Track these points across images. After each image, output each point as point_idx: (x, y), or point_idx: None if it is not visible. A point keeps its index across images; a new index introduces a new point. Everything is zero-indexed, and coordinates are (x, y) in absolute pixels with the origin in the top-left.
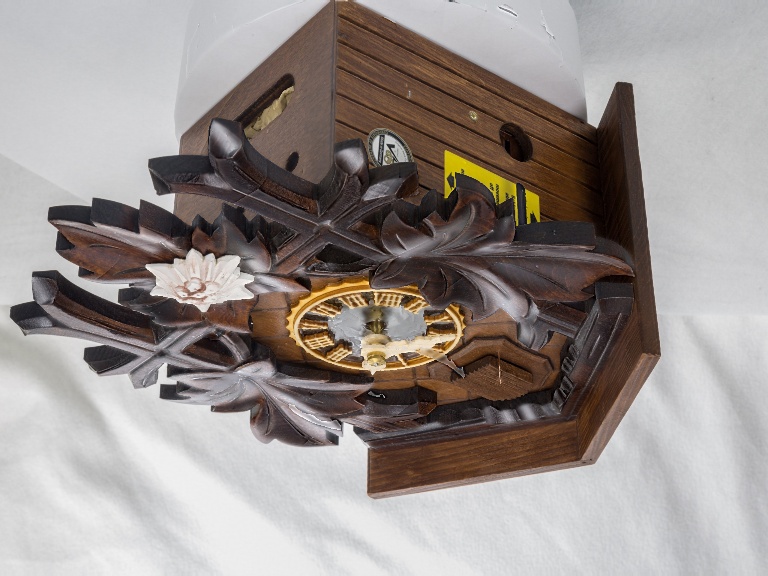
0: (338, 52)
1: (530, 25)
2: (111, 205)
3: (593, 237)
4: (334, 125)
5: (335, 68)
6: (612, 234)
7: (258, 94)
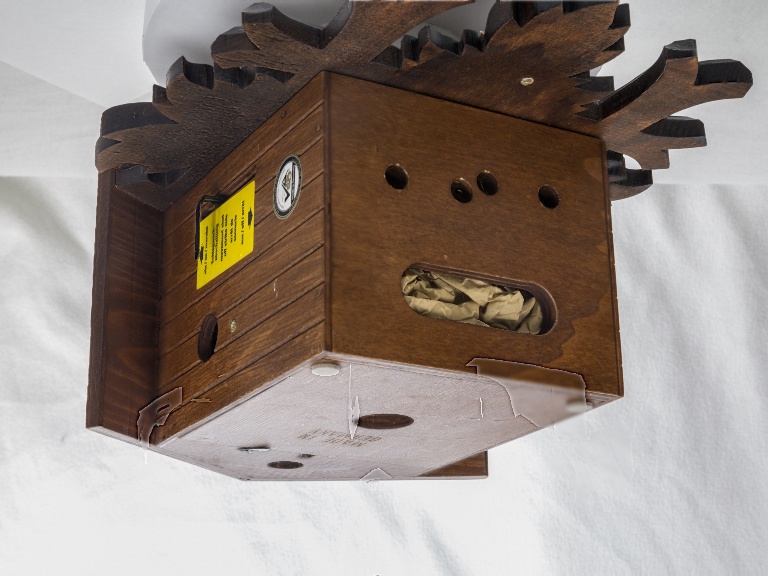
0: (323, 264)
1: (150, 415)
2: (544, 6)
3: (103, 121)
4: (325, 165)
5: (326, 242)
6: (146, 290)
7: (470, 328)
